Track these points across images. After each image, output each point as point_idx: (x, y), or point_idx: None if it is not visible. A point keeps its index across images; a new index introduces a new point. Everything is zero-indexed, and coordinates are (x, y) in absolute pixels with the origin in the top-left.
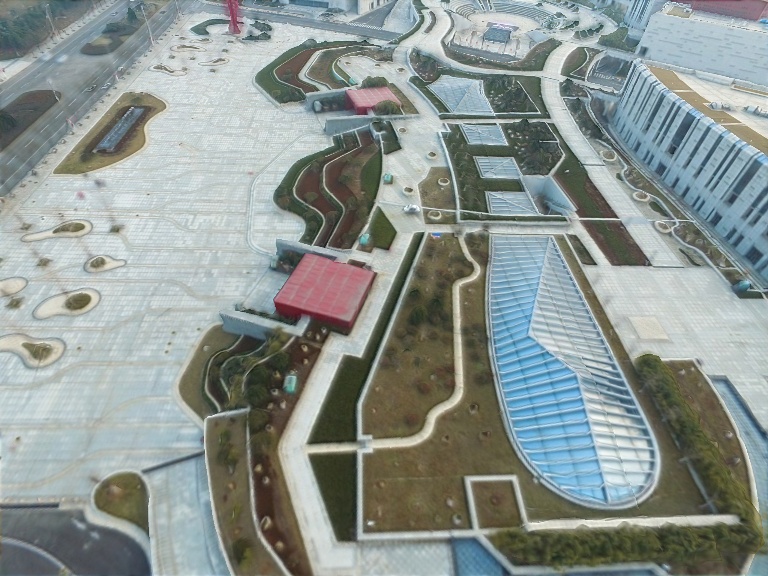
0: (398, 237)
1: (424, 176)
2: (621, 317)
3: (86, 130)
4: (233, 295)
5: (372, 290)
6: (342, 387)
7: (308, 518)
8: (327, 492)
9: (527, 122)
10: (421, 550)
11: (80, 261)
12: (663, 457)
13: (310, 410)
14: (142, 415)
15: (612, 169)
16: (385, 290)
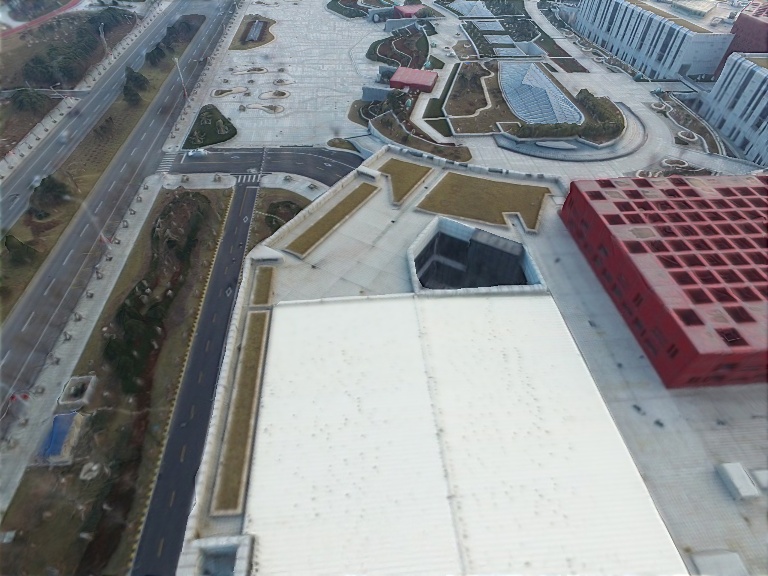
0: (446, 65)
1: (455, 44)
2: (571, 87)
3: (234, 32)
4: (360, 91)
5: (437, 81)
6: (433, 105)
7: (430, 133)
8: (436, 127)
9: (516, 18)
10: (480, 138)
11: (270, 81)
12: (586, 119)
13: (420, 111)
14: (335, 125)
15: (571, 40)
16: (444, 81)
